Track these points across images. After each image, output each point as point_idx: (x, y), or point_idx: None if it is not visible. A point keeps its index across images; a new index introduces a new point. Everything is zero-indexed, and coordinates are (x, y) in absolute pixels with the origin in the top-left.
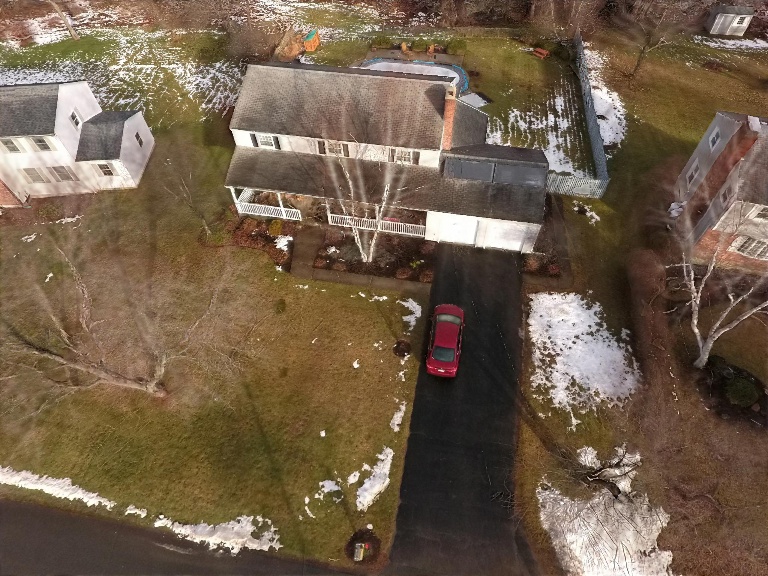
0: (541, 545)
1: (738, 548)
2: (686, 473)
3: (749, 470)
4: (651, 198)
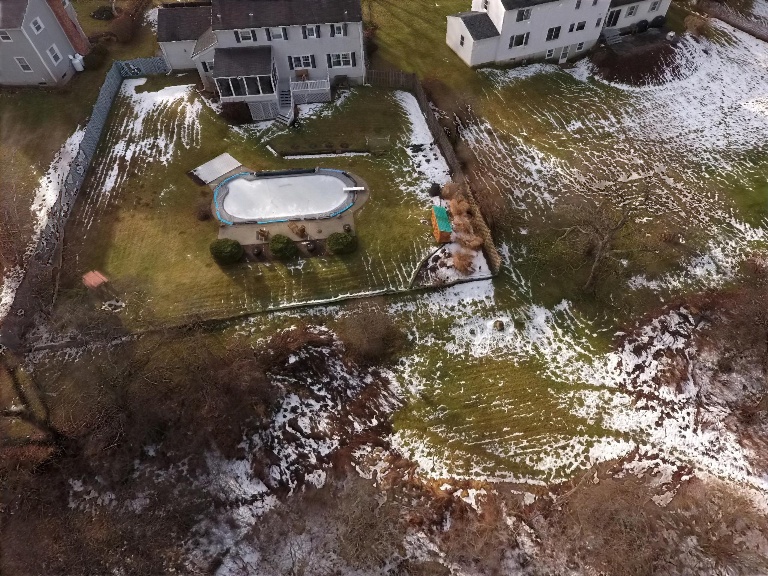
0: None
1: None
2: None
3: (118, 0)
4: (85, 80)
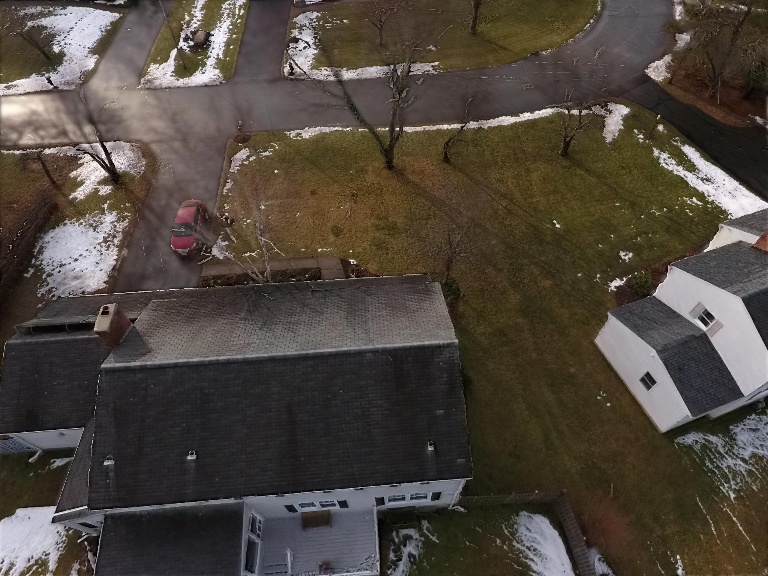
0: (149, 154)
1: (39, 170)
2: (45, 193)
3: (1, 202)
4: None
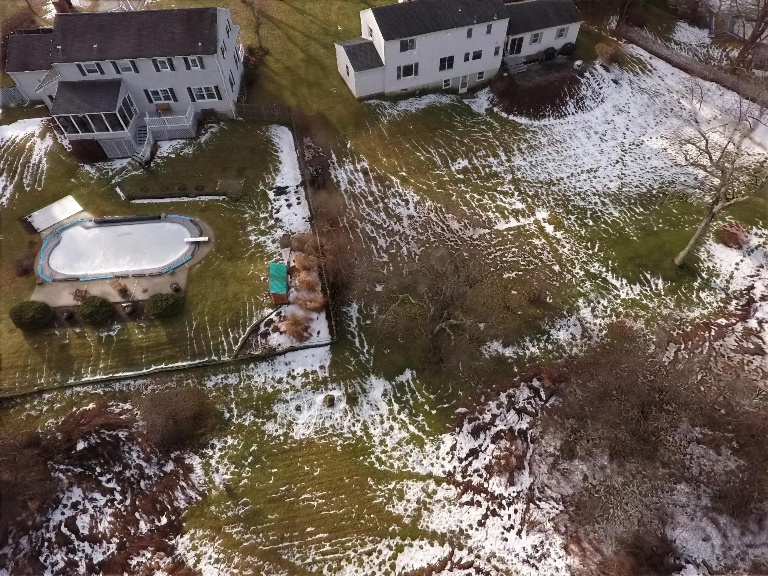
0: None
1: None
2: (27, 16)
3: None
4: None
